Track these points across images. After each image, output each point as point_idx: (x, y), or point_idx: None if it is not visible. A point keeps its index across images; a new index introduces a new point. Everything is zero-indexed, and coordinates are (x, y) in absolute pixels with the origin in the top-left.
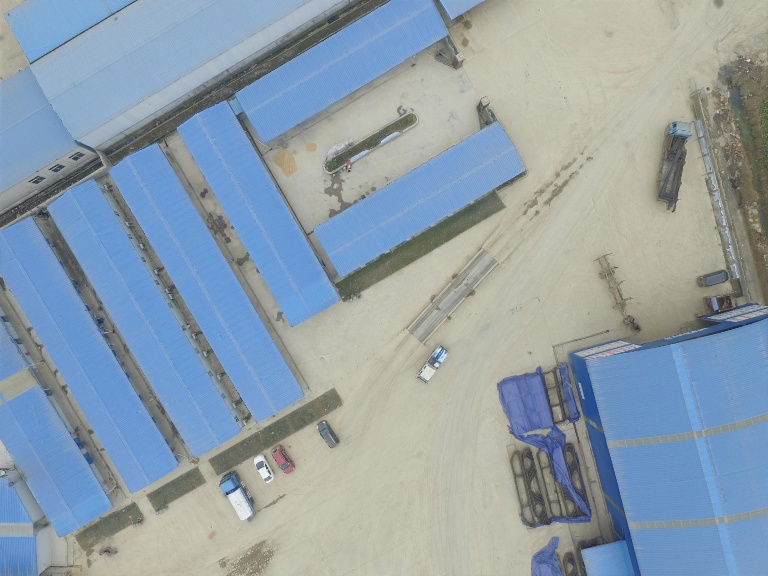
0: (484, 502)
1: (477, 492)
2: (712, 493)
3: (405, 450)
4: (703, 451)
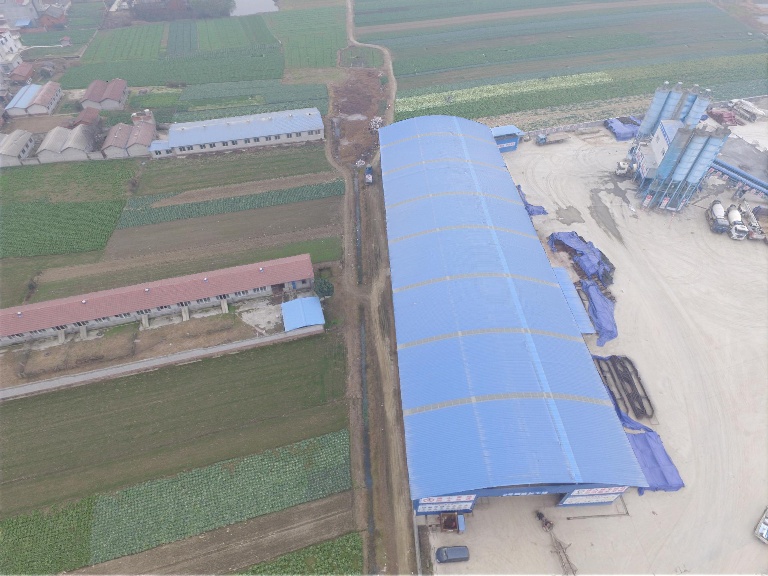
0: (670, 382)
1: (678, 391)
2: (534, 350)
3: (764, 440)
4: (544, 381)
